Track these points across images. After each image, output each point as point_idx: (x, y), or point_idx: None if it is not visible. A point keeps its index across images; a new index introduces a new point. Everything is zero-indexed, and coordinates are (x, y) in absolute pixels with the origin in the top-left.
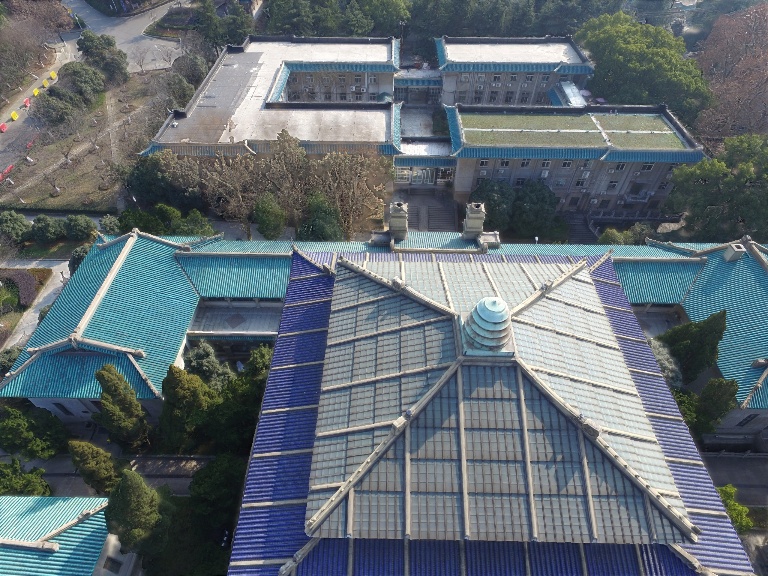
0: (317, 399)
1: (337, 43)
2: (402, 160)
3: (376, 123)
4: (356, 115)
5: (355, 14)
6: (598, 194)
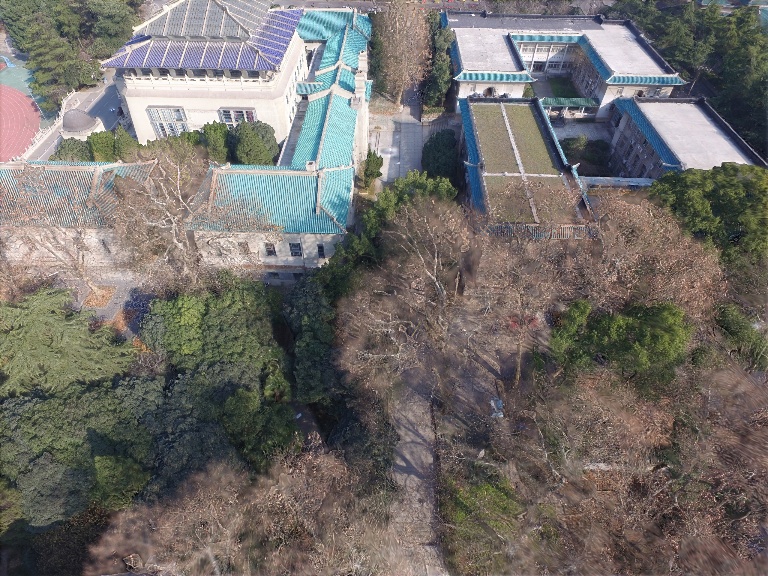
0: None
1: (649, 55)
2: None
3: (496, 70)
4: (507, 63)
5: (698, 44)
6: None
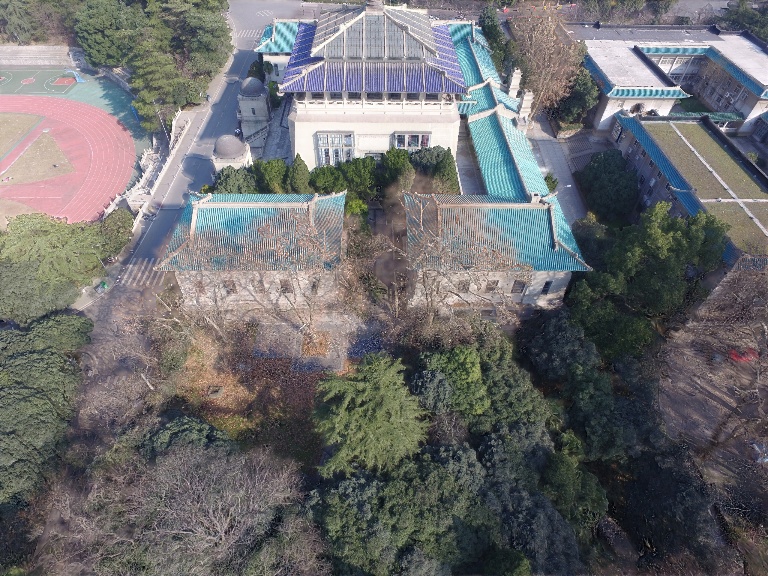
0: None
1: None
2: None
3: (644, 85)
4: (651, 78)
5: None
6: None
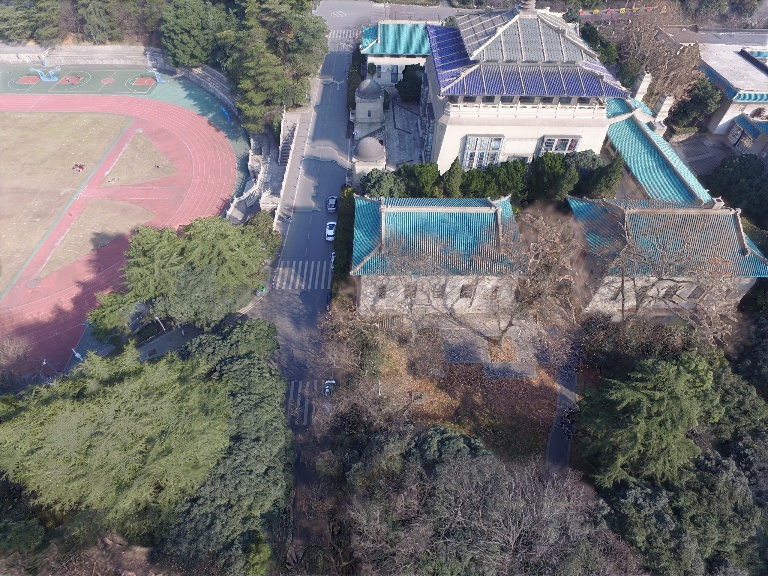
0: None
1: None
2: (743, 119)
3: (765, 89)
4: None
5: None
6: None
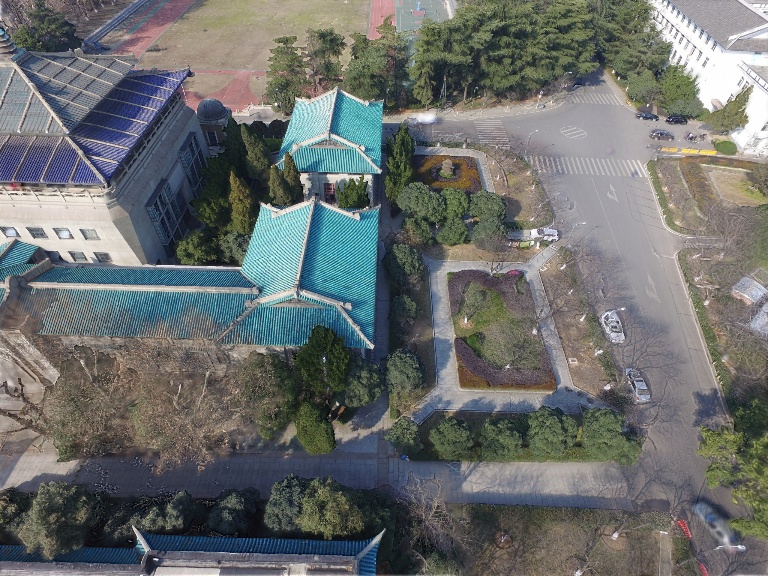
0: (124, 105)
1: None
2: None
3: None
4: None
5: None
6: None
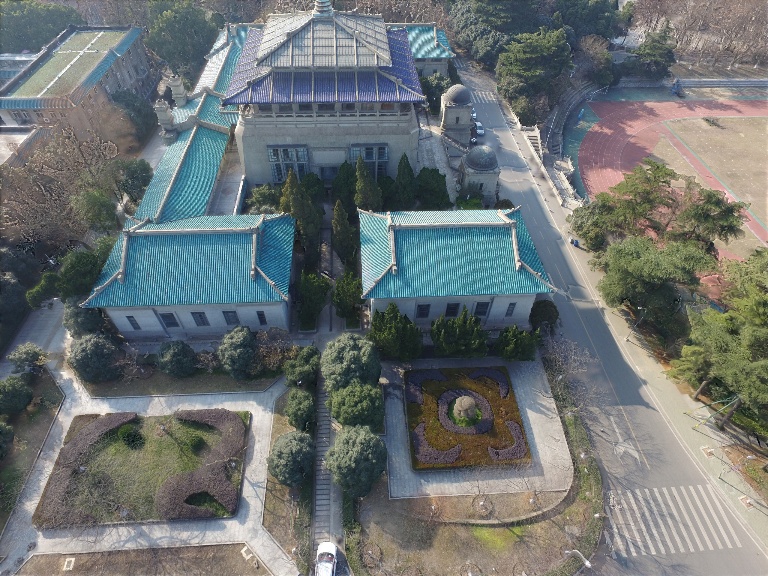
0: (333, 83)
1: None
2: None
3: None
4: None
5: None
6: (131, 86)
